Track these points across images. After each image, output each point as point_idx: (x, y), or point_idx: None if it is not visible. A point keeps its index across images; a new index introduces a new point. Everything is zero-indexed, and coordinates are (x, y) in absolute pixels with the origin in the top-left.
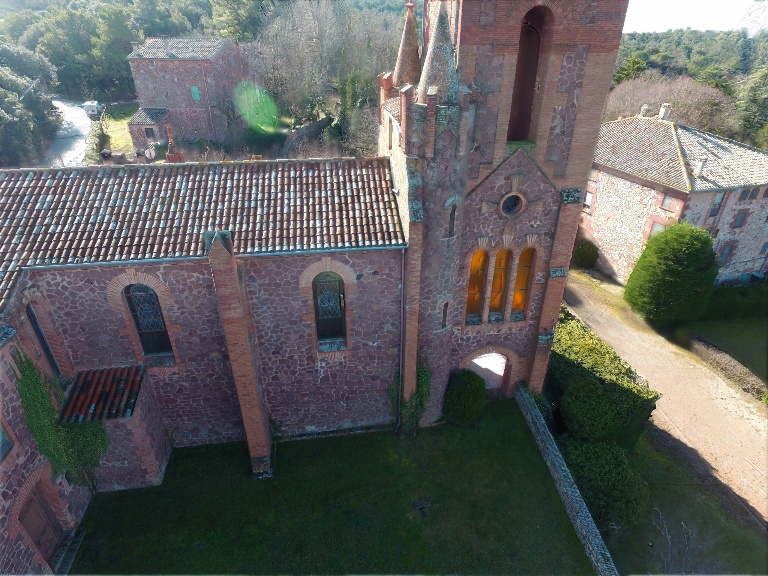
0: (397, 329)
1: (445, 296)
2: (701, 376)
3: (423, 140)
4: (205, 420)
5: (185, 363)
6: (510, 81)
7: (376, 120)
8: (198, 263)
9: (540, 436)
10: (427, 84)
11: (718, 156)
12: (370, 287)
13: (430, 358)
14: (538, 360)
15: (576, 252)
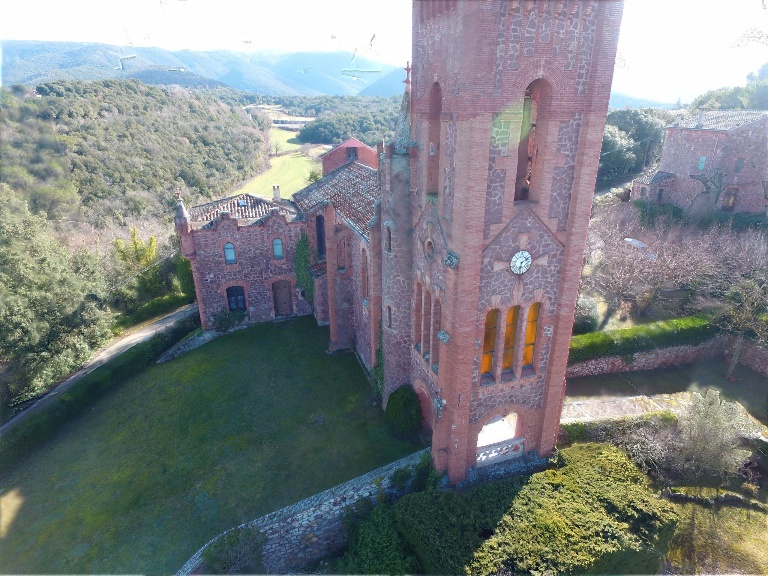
0: None
1: (388, 300)
2: None
3: None
4: None
5: None
6: None
7: None
8: None
9: None
10: None
11: None
12: None
13: None
14: None
15: None
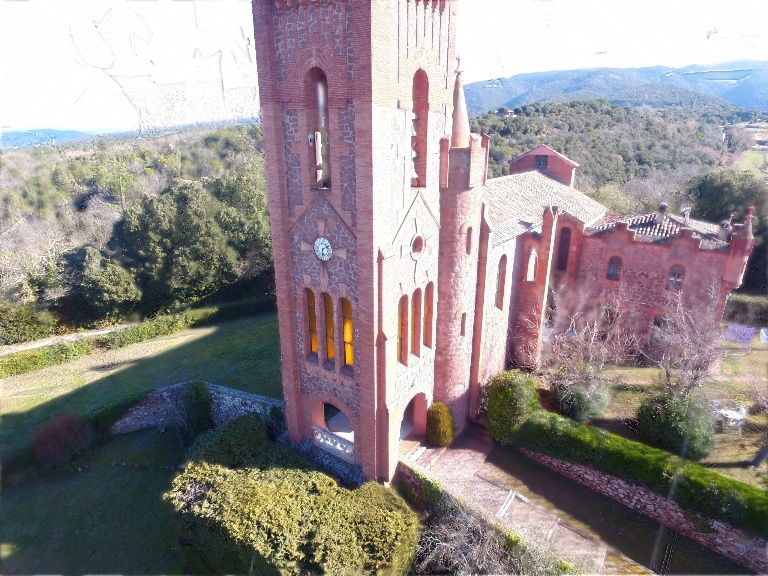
0: None
1: None
2: None
3: None
4: None
5: None
6: None
7: None
8: None
9: None
10: None
11: None
12: None
13: None
14: None
15: None
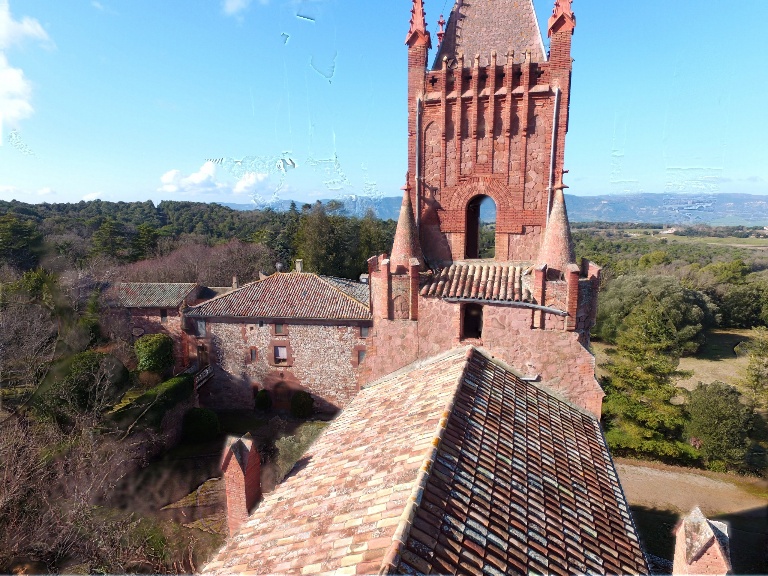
0: None
1: None
2: None
3: (588, 312)
4: None
5: None
6: None
7: None
8: None
9: None
10: (571, 261)
11: None
12: None
13: None
14: None
15: (294, 406)
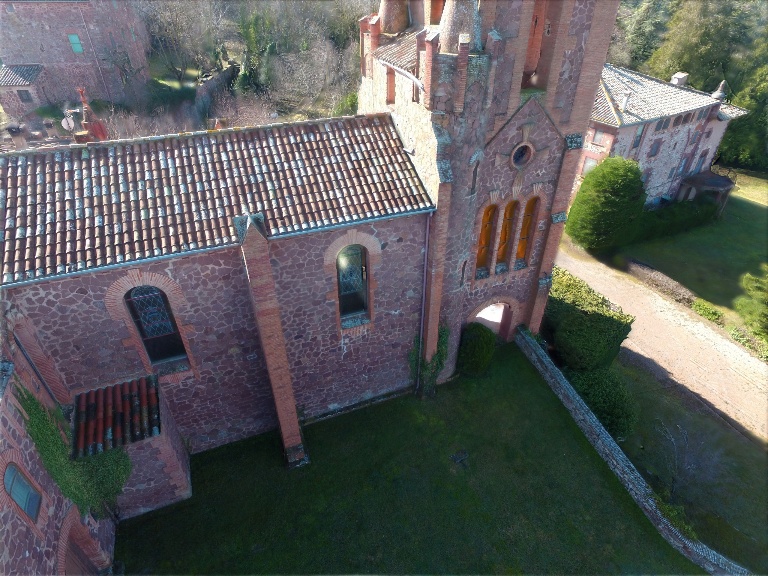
0: (418, 294)
1: (465, 255)
2: (641, 294)
3: (451, 94)
4: (224, 420)
5: (201, 364)
6: (527, 25)
7: (300, 68)
8: (213, 253)
9: (549, 373)
10: (452, 31)
11: (634, 90)
12: (394, 255)
13: (449, 317)
14: (538, 303)
15: None
